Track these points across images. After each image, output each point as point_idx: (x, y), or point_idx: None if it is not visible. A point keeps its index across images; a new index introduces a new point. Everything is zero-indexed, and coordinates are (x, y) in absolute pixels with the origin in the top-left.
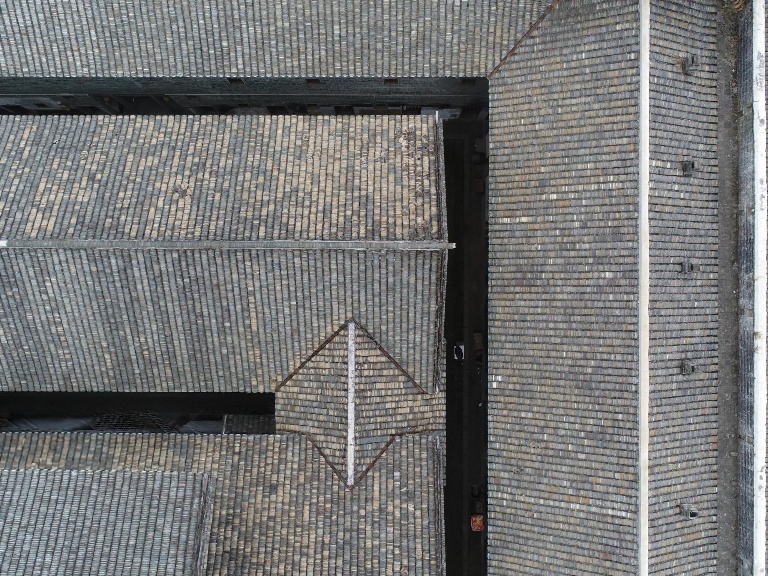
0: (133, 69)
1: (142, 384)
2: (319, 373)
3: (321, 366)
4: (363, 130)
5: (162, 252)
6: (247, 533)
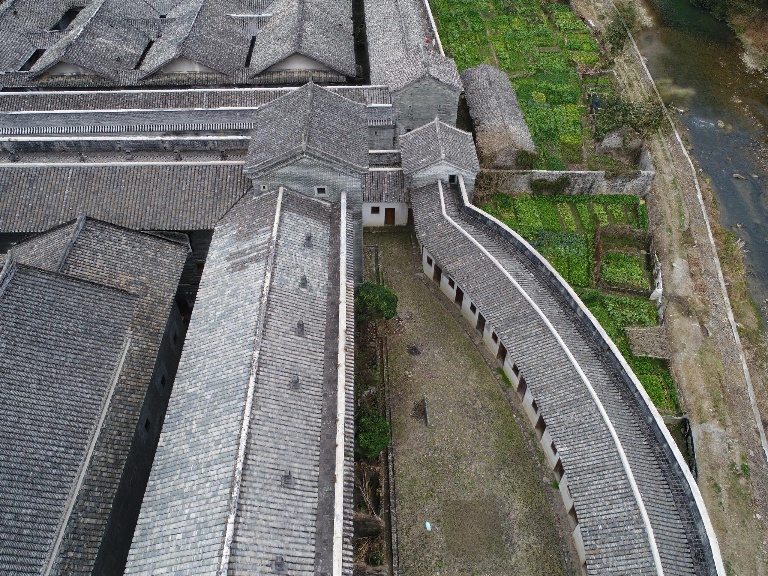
0: None
1: None
2: None
3: None
4: None
5: None
6: None
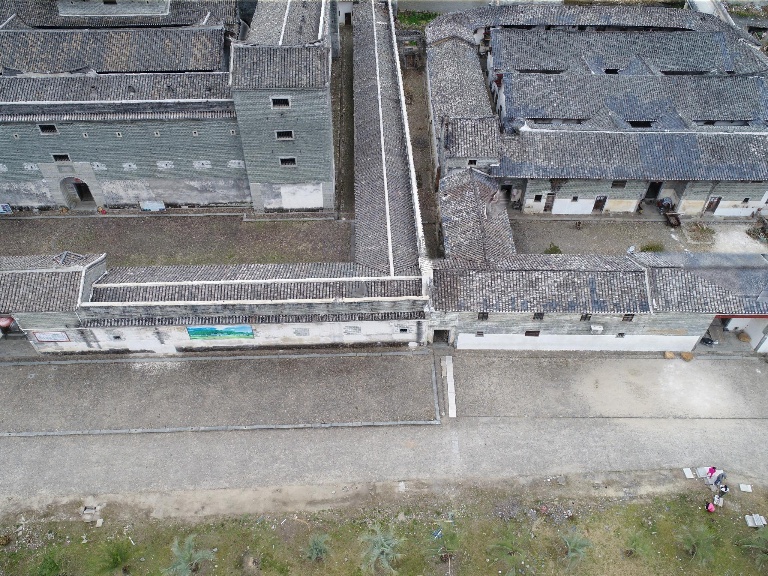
0: None
1: None
2: None
3: None
4: None
5: None
6: (48, 4)
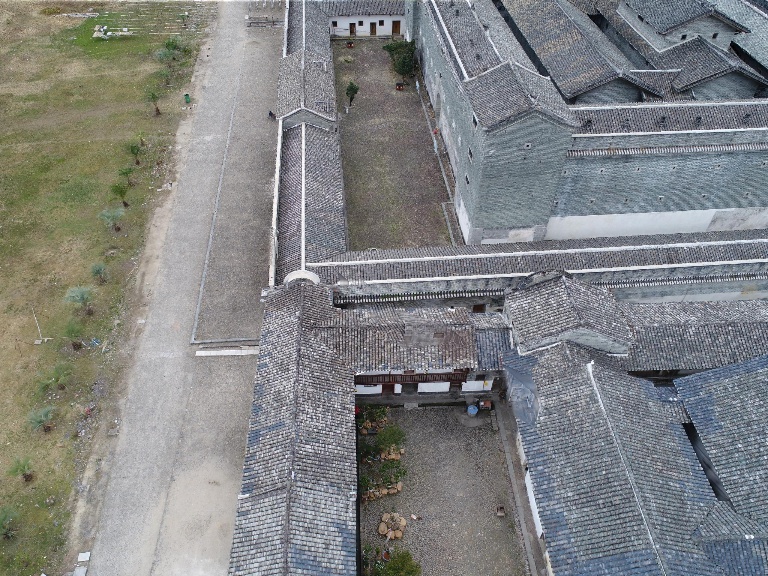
0: None
1: None
2: (577, 3)
3: (575, 3)
4: (508, 3)
5: None
6: None
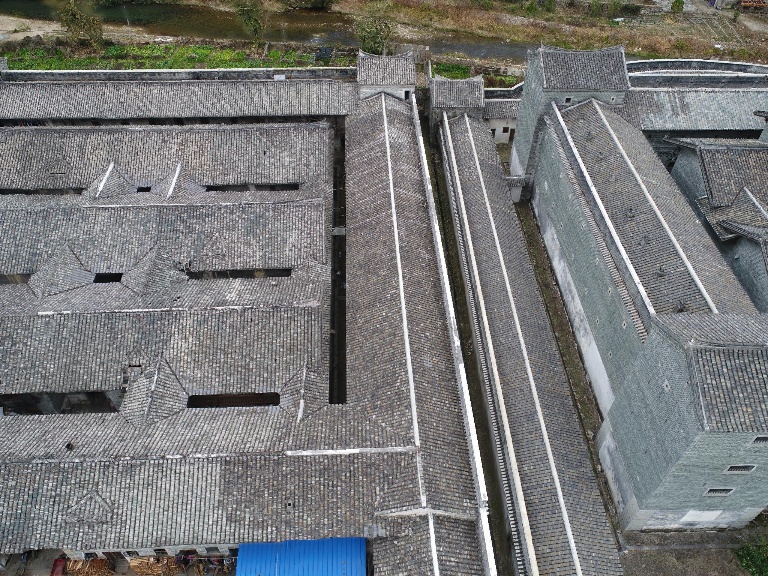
0: None
1: None
2: None
3: None
4: None
5: None
6: None
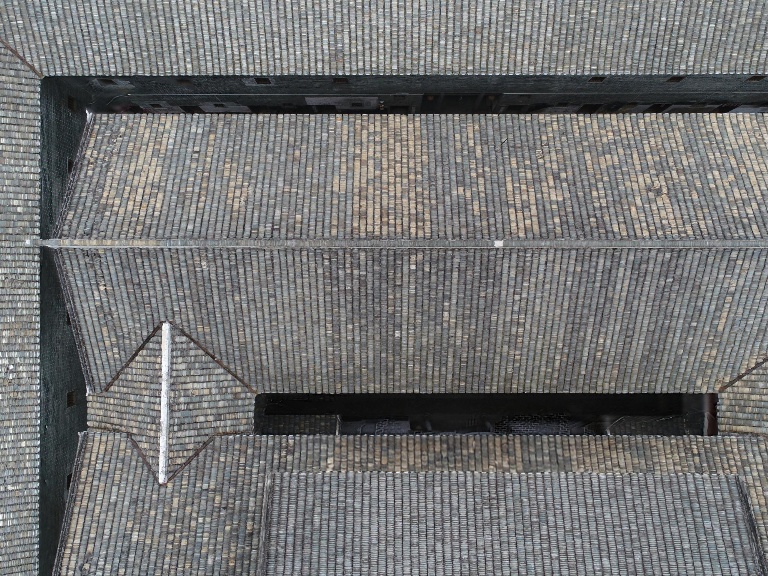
0: (581, 67)
1: (583, 385)
2: None
3: None
4: None
5: (656, 251)
6: None
